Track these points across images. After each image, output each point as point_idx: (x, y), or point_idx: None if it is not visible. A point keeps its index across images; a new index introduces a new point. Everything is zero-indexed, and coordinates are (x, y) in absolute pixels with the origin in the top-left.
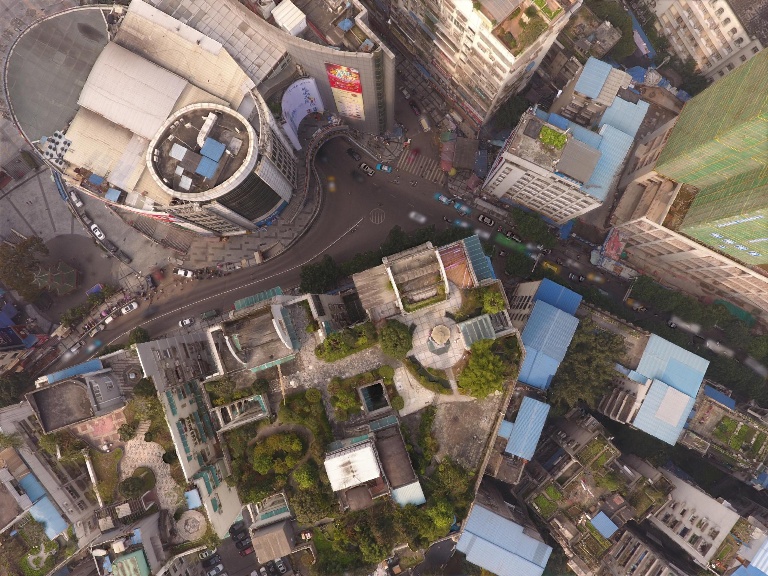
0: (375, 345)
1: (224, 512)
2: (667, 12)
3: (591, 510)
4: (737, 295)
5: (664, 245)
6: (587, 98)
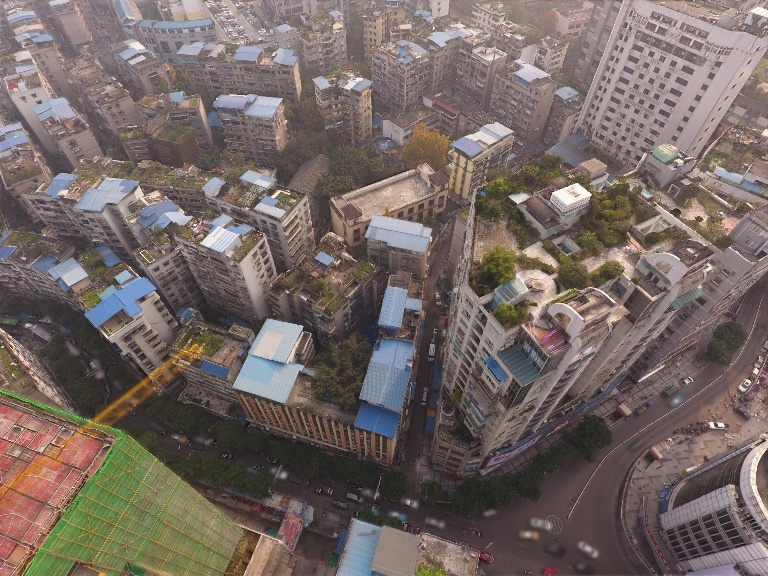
0: None
1: None
2: None
3: (331, 269)
4: None
5: None
6: None
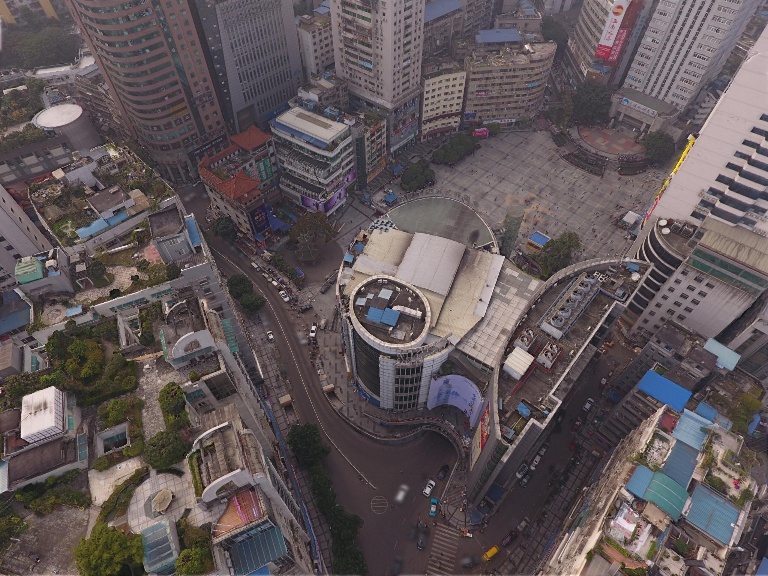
0: None
1: None
2: None
3: None
4: None
5: None
6: None
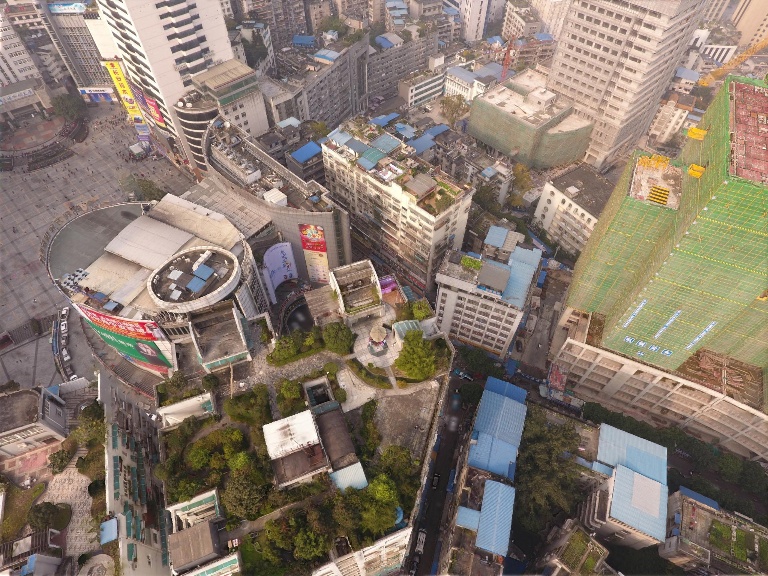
0: (322, 352)
1: (138, 574)
2: (551, 226)
3: None
4: (688, 422)
5: (599, 371)
6: (496, 250)
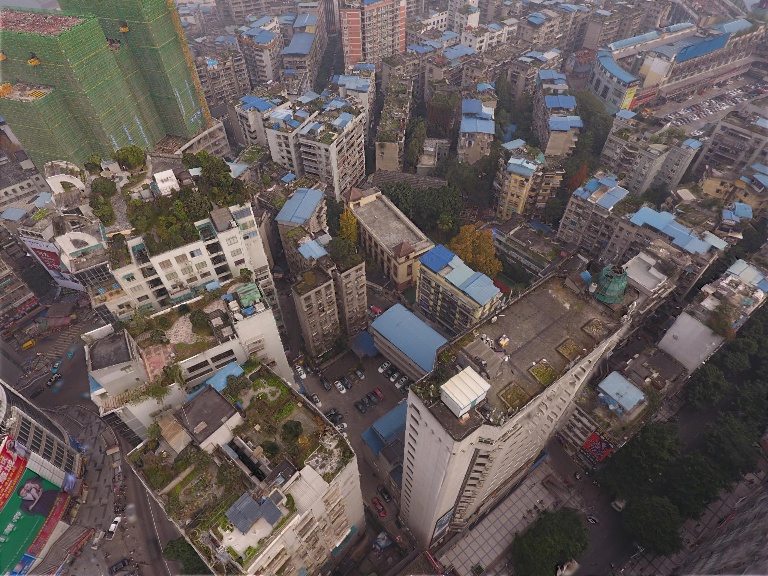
0: (111, 203)
1: None
2: None
3: None
4: None
5: None
6: None
